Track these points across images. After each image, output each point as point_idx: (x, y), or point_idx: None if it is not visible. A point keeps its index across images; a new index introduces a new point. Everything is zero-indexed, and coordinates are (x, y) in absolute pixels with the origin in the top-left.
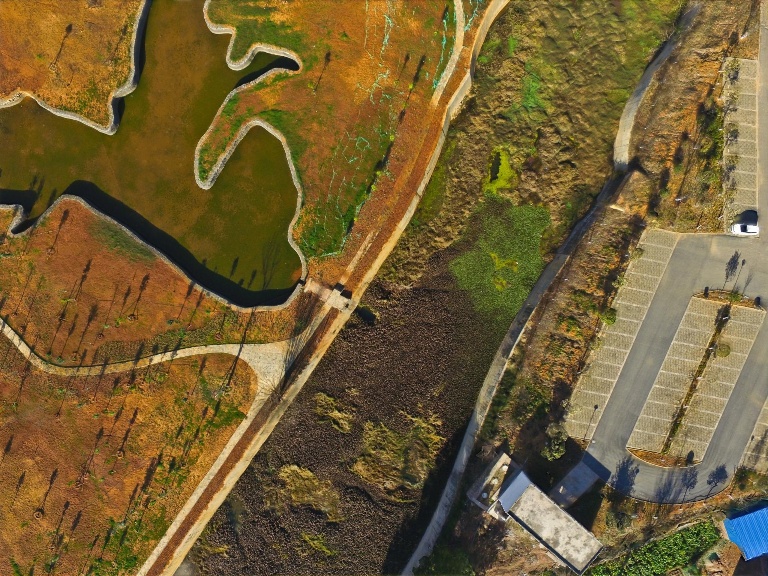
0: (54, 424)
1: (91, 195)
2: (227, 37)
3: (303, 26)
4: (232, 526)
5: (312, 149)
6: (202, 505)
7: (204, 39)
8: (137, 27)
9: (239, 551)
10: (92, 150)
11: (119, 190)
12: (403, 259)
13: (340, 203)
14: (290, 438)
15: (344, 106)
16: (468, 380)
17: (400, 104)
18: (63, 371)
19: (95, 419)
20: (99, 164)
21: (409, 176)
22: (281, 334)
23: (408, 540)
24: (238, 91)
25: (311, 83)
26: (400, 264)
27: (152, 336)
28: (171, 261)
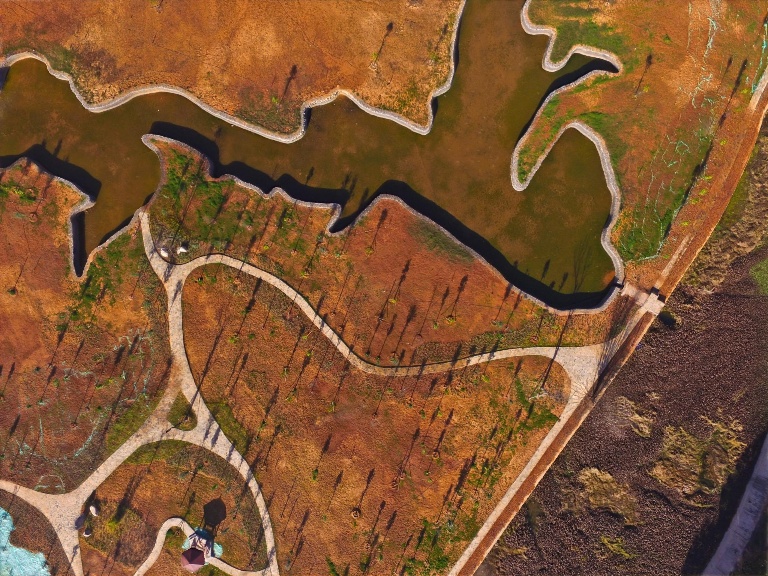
0: (371, 424)
1: (398, 195)
2: (541, 38)
3: (625, 28)
4: (530, 528)
5: (631, 152)
6: (513, 507)
7: (518, 40)
8: (457, 26)
9: (537, 553)
10: (405, 150)
11: (431, 190)
12: (705, 264)
13: (658, 207)
14: (590, 441)
15: (665, 109)
16: (767, 386)
17: (721, 108)
18: (382, 371)
19: (412, 419)
20: (411, 164)
21: (725, 181)
22: (596, 337)
23: (707, 545)
24: (558, 93)
25: (648, 86)
26: (702, 269)
27: (469, 337)
28: (489, 263)
